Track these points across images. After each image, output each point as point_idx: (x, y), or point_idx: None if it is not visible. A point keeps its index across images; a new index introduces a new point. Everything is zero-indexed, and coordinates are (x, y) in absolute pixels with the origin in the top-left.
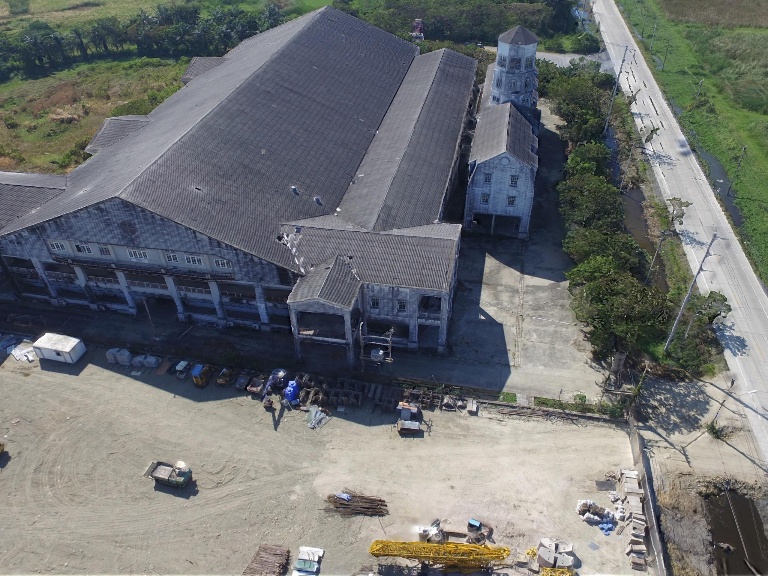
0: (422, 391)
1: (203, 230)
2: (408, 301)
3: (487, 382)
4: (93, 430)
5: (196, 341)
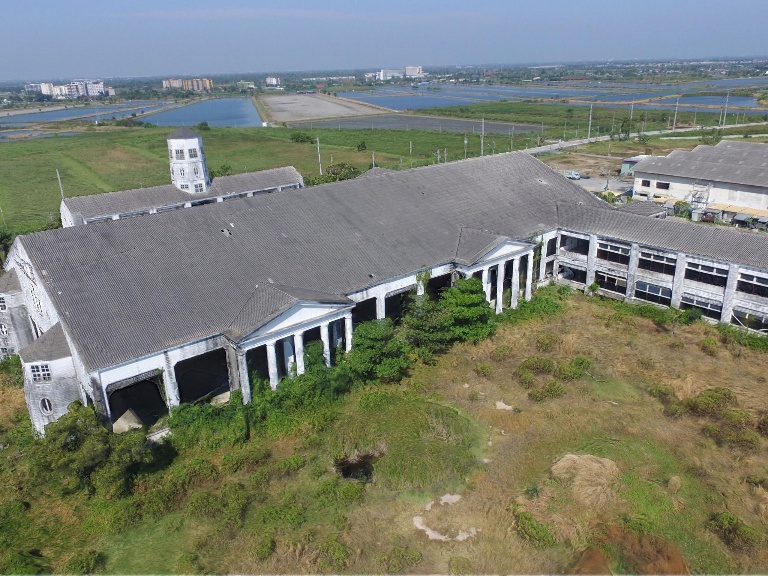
0: None
1: None
2: None
3: None
4: None
5: None
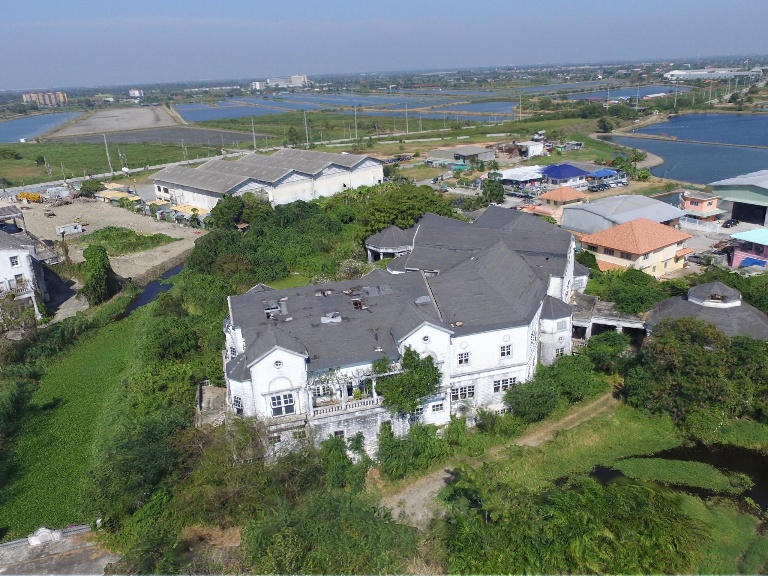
0: None
1: None
2: None
3: None
4: None
5: None
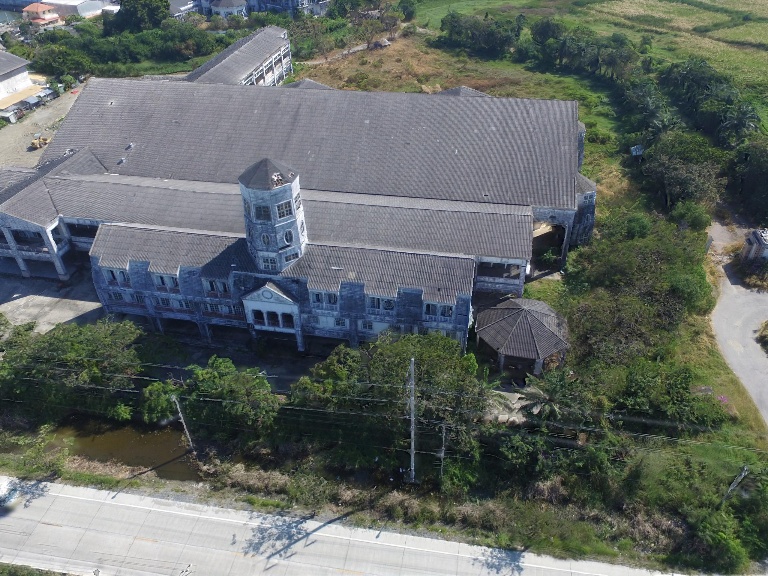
0: None
1: (69, 116)
2: None
3: None
4: None
5: None
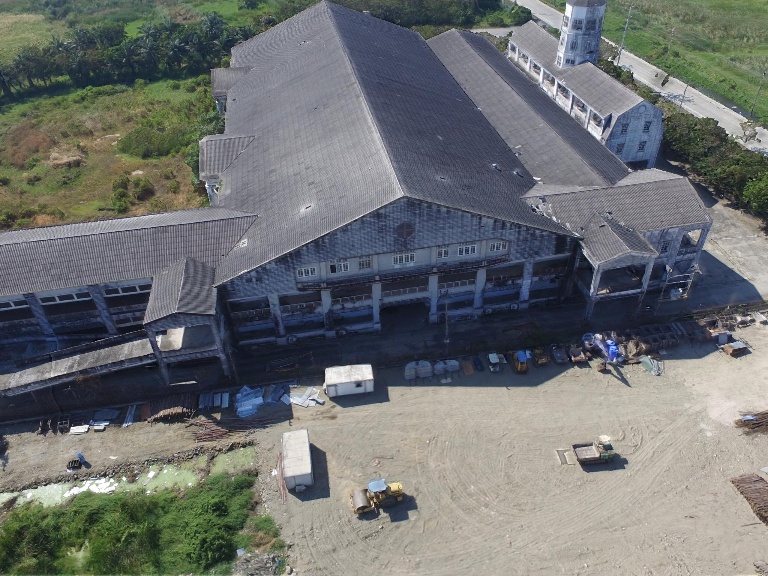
0: (717, 317)
1: (488, 214)
2: (673, 240)
3: (746, 297)
4: (466, 443)
5: (467, 336)
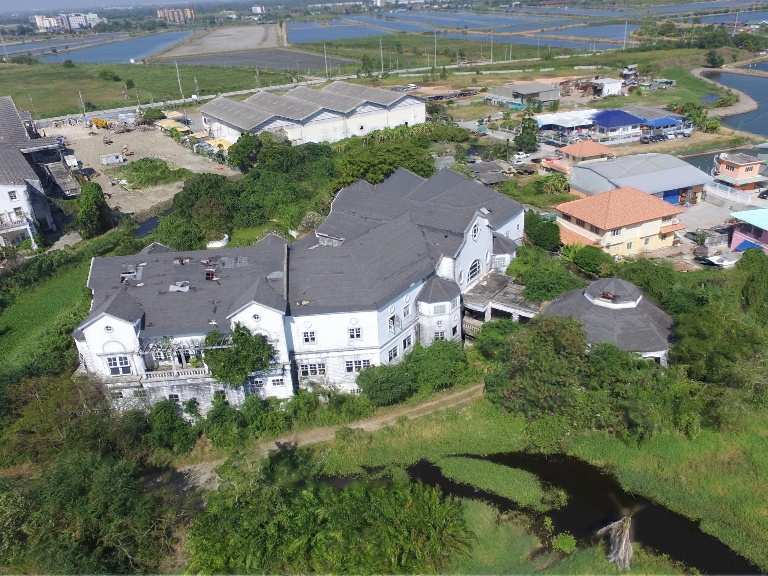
0: None
1: None
2: None
3: None
4: None
5: None
